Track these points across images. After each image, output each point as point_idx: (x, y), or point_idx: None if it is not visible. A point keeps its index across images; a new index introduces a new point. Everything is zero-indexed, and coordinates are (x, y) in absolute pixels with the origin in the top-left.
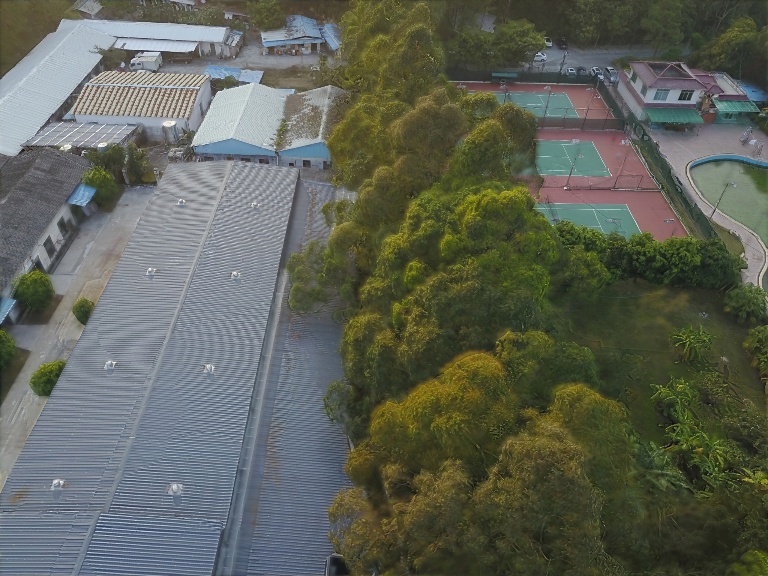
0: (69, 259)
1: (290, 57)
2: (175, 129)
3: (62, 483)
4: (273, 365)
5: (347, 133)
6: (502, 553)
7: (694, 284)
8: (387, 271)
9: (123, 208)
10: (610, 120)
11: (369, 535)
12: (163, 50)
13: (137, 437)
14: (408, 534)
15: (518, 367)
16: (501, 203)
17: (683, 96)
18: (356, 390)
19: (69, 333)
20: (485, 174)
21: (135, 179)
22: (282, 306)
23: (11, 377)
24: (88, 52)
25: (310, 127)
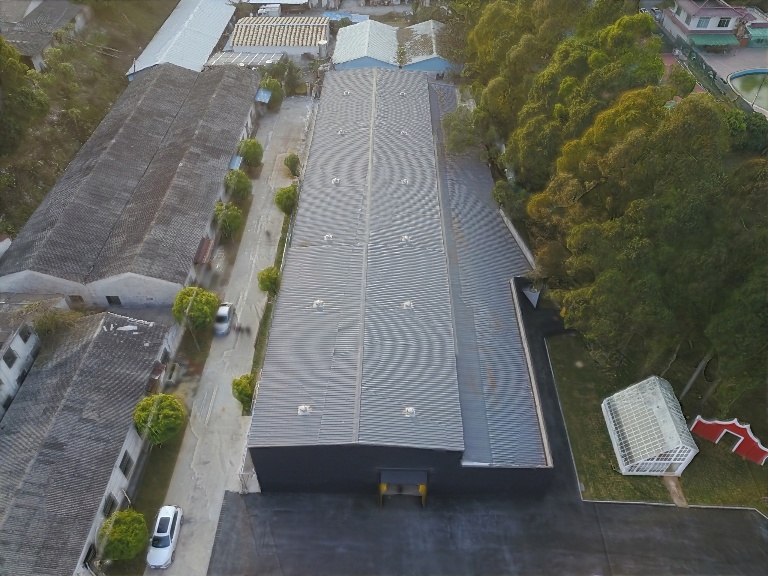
0: (259, 141)
1: (384, 7)
2: (326, 47)
3: (331, 237)
4: (443, 186)
5: (491, 20)
6: (669, 163)
7: (741, 146)
8: (540, 96)
9: (286, 110)
10: (661, 44)
11: (579, 188)
12: (282, 3)
13: (371, 214)
14: (611, 168)
15: (657, 103)
16: (636, 19)
17: (722, 23)
18: (525, 170)
19: (277, 184)
20: (609, 24)
21: (290, 91)
22: (438, 155)
23: (246, 208)
24: (225, 4)
25: (424, 48)
